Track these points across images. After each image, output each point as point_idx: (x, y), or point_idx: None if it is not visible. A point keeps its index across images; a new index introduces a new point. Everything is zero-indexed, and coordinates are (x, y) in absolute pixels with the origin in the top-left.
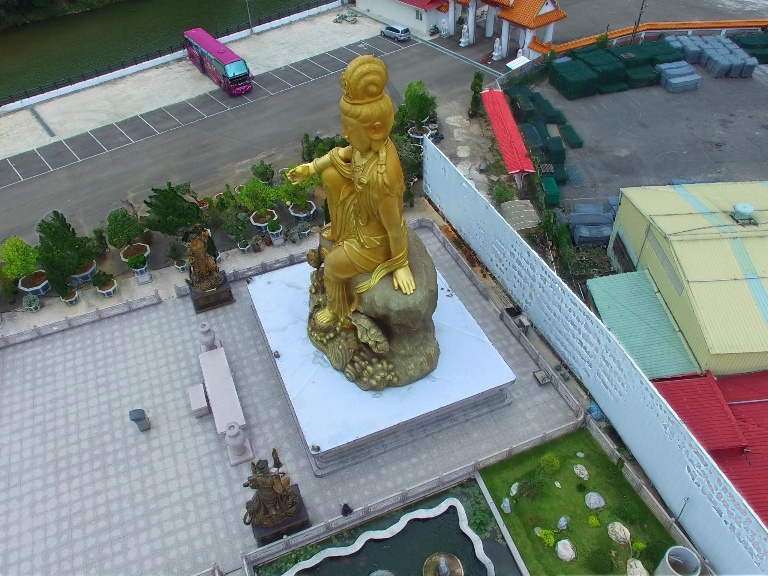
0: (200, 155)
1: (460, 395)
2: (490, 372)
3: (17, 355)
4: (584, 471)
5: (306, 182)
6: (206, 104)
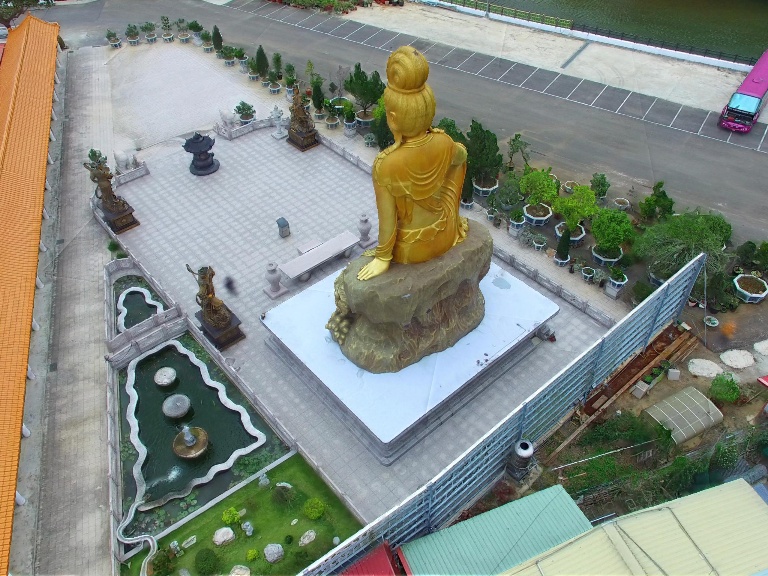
0: (606, 145)
1: (348, 399)
2: (386, 419)
3: (325, 156)
4: (307, 539)
5: (573, 205)
6: (691, 118)
